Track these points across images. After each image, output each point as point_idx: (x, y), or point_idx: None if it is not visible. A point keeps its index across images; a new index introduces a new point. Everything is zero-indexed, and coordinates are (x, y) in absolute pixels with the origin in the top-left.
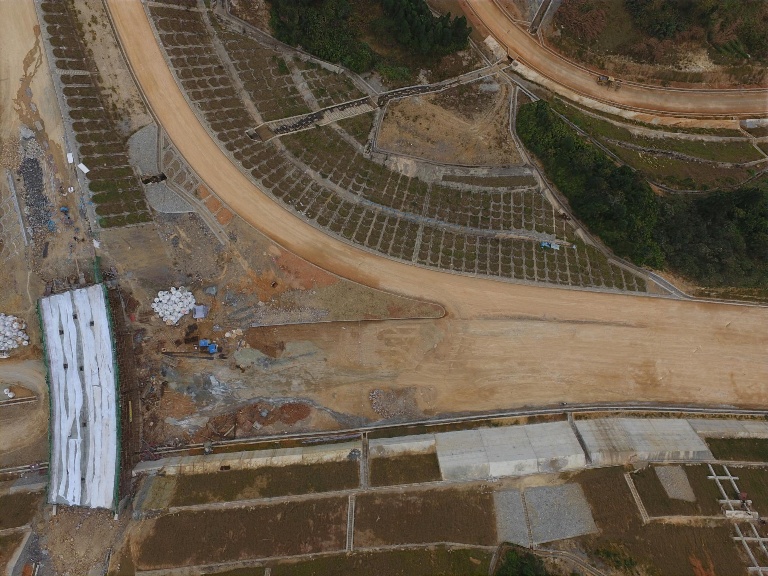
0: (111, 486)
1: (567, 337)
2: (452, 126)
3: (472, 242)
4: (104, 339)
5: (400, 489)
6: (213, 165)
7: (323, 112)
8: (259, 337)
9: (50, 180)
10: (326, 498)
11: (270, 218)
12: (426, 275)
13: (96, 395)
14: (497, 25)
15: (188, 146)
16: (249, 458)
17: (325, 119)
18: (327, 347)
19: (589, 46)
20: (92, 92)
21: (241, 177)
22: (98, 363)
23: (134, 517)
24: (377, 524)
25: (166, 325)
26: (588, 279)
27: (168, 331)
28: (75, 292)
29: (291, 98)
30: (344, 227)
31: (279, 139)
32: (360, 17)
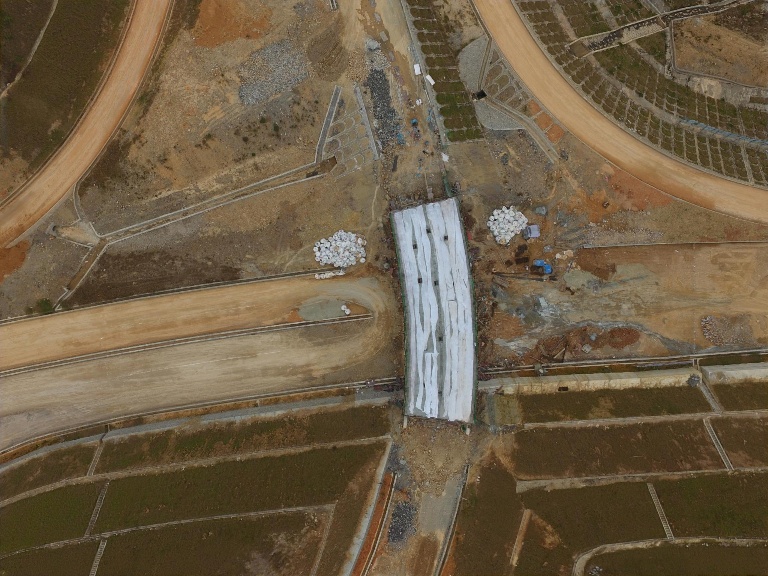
0: (469, 400)
1: None
2: (740, 48)
3: None
4: (459, 254)
5: (756, 414)
6: (543, 80)
7: (622, 30)
8: (590, 259)
9: (397, 92)
10: (680, 420)
11: (602, 135)
12: (764, 197)
13: (452, 310)
14: None
15: (518, 60)
16: (587, 380)
17: (625, 37)
18: (659, 270)
19: None
20: (426, 3)
21: (572, 92)
22: (453, 278)
23: (491, 431)
24: (747, 446)
25: (497, 245)
26: None
27: (500, 251)
28: (428, 206)
29: (593, 14)
30: (673, 146)
31: (593, 56)
32: None
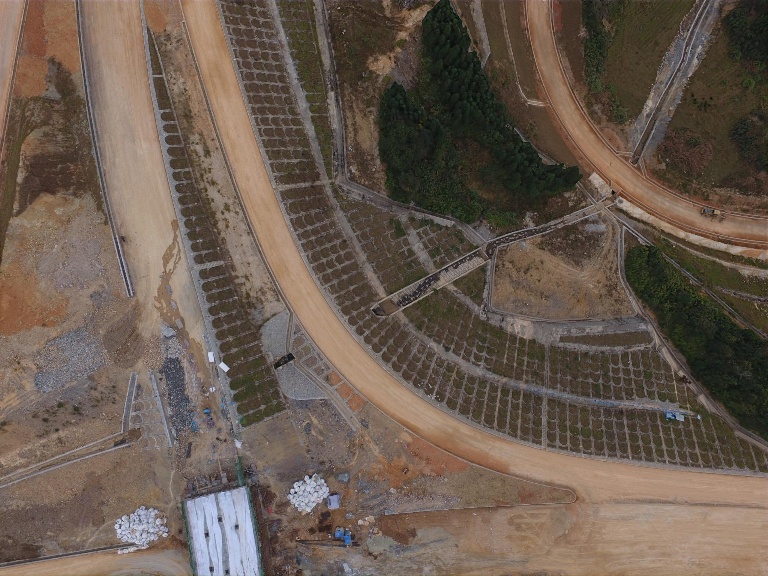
0: None
1: (698, 520)
2: (561, 273)
3: (597, 416)
4: (249, 543)
5: None
6: (344, 351)
7: (439, 273)
8: (391, 524)
9: (192, 379)
10: None
11: (401, 403)
12: (556, 459)
13: None
14: (599, 158)
15: (319, 332)
16: None
17: (441, 280)
18: (458, 533)
19: (695, 179)
20: (227, 282)
21: (372, 362)
22: (244, 567)
23: None
24: None
25: (300, 513)
26: (719, 459)
27: (302, 520)
28: (219, 495)
29: (409, 262)
30: (472, 408)
31: (402, 312)
32: (469, 165)
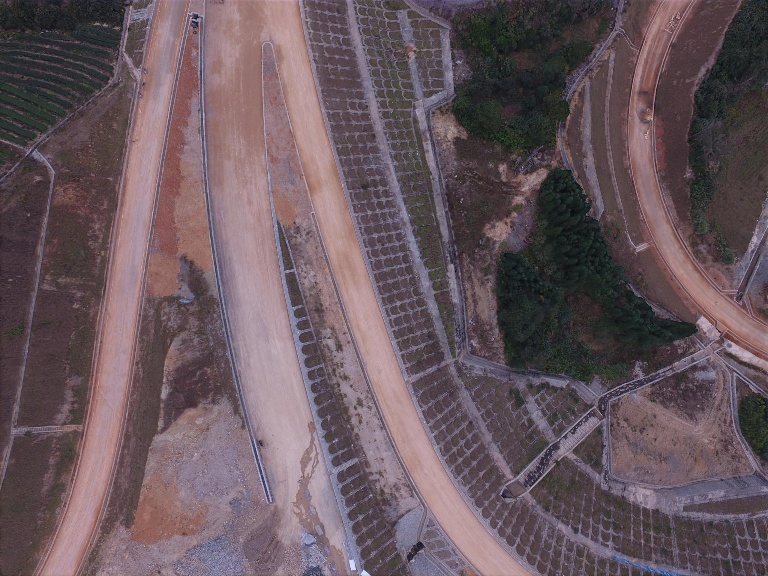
0: None
1: None
2: (675, 428)
3: None
4: None
5: None
6: (479, 545)
7: (559, 442)
8: None
9: None
10: None
11: None
12: None
13: None
14: (704, 297)
15: (454, 527)
16: None
17: (561, 449)
18: None
19: None
20: (362, 481)
21: (507, 556)
22: None
23: None
24: None
25: None
26: None
27: None
28: None
29: (530, 434)
30: None
31: (529, 493)
32: (580, 320)
